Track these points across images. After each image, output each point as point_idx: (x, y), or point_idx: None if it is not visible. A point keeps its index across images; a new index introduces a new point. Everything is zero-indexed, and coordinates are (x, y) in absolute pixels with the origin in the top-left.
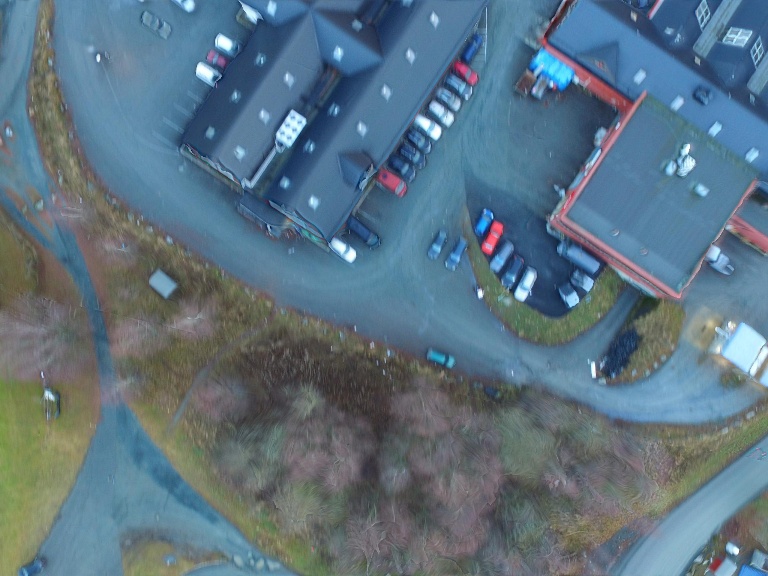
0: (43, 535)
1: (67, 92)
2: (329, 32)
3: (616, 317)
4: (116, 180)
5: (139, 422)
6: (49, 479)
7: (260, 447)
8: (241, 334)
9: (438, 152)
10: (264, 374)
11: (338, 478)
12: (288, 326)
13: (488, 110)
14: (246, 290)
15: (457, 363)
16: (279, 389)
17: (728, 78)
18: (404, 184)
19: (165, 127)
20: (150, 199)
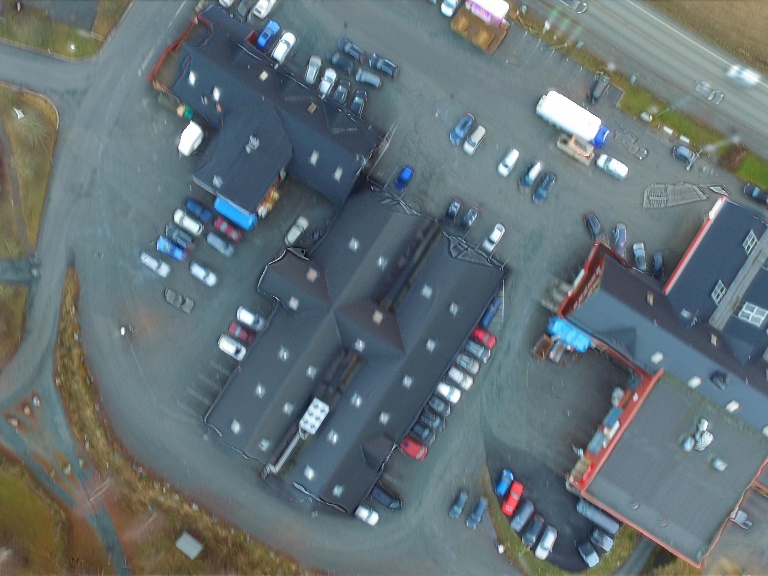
0: None
1: (93, 365)
2: (350, 327)
3: (635, 563)
4: (142, 449)
5: None
6: None
7: None
8: None
9: (457, 413)
10: None
11: None
12: None
13: (506, 371)
14: (271, 554)
15: None
16: None
17: (745, 359)
18: (425, 449)
19: (189, 397)
20: (175, 467)
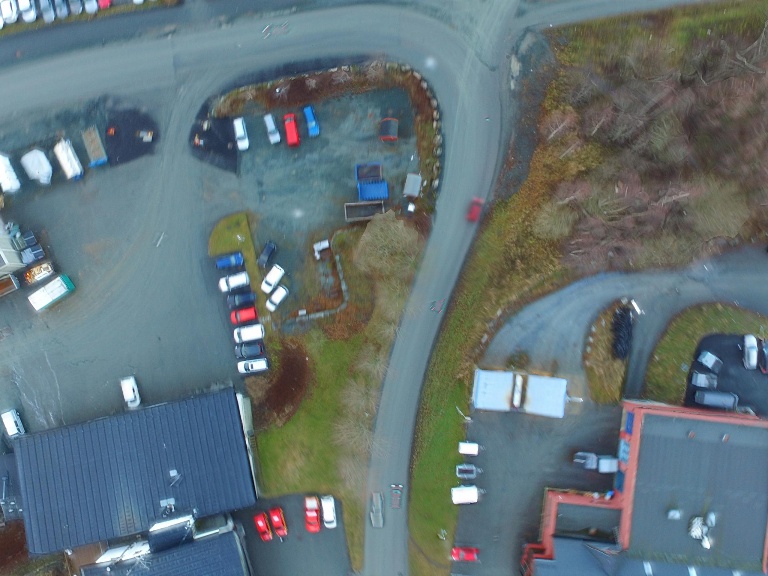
0: None
1: None
2: None
3: (639, 364)
4: None
5: None
6: None
7: None
8: None
9: None
10: None
11: None
12: None
13: None
14: None
15: (763, 252)
16: None
17: None
18: None
19: None
20: None
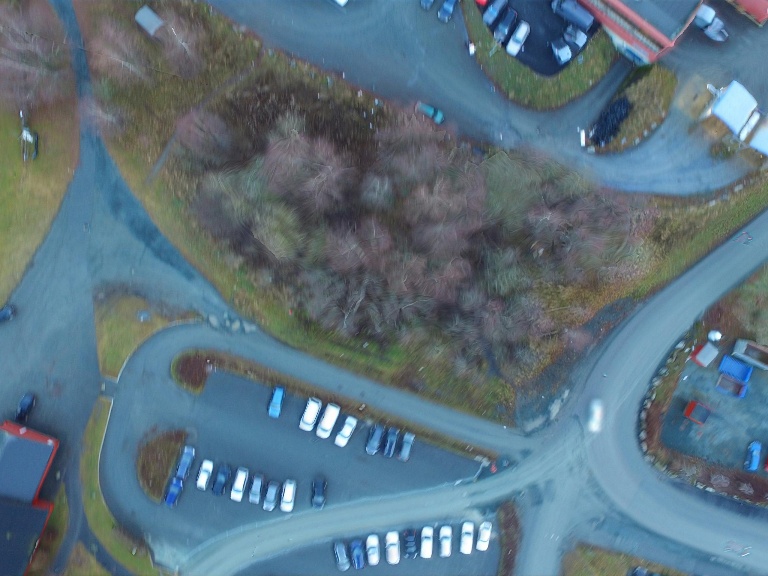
0: (14, 283)
1: None
2: None
3: (608, 87)
4: None
5: (118, 170)
6: (23, 225)
7: (241, 176)
8: (227, 79)
9: None
10: (249, 120)
11: (319, 203)
12: (275, 69)
13: None
14: (234, 27)
15: (445, 121)
16: (263, 136)
17: None
18: None
19: None
20: None
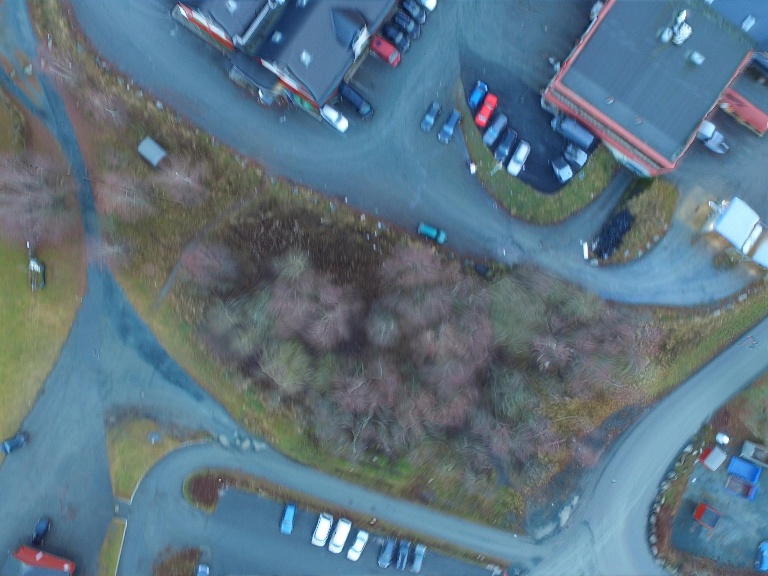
0: (26, 410)
1: None
2: None
3: (609, 198)
4: (106, 43)
5: (126, 296)
6: (33, 352)
7: (247, 311)
8: (230, 205)
9: (433, 23)
10: (253, 246)
11: (326, 339)
12: (278, 196)
13: None
14: (236, 157)
15: (448, 239)
16: (268, 261)
17: None
18: (398, 53)
19: None
20: (140, 63)
